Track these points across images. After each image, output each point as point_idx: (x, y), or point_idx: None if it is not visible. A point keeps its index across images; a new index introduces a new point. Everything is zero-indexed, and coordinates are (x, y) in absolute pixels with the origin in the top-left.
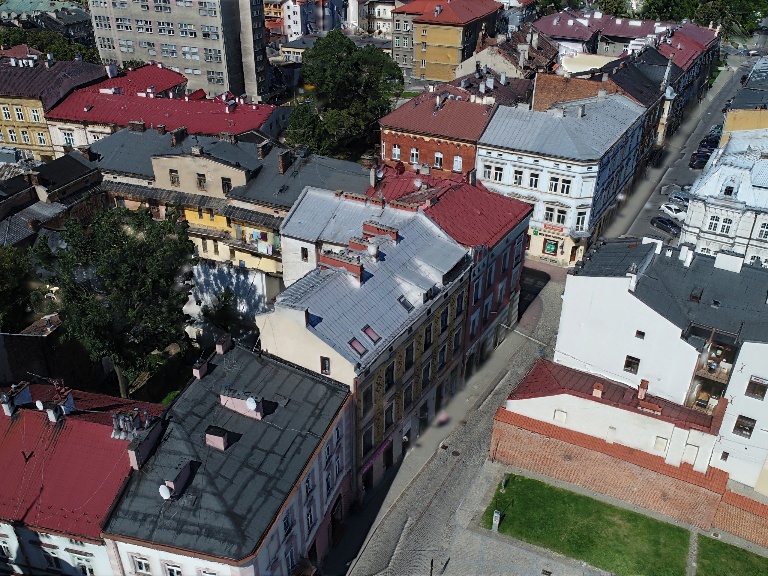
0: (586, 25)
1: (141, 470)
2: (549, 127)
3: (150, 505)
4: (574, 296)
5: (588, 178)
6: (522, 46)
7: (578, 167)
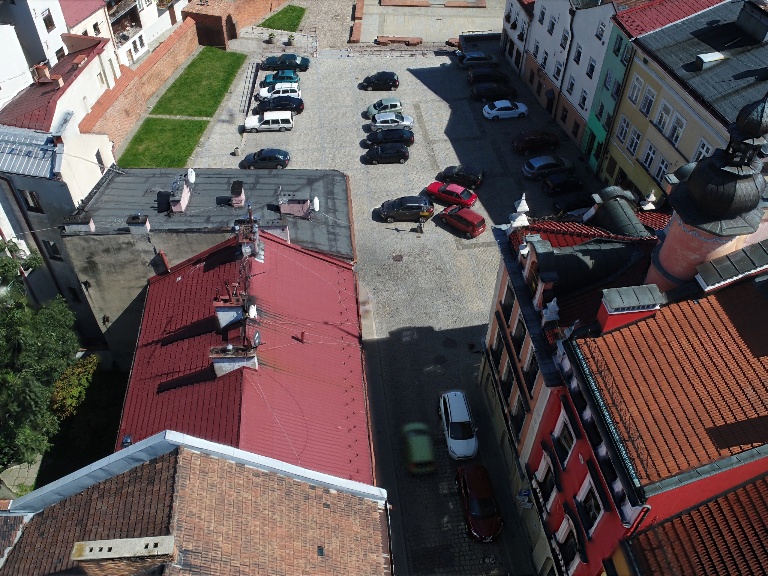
0: None
1: None
2: None
3: (320, 232)
4: None
5: None
6: None
7: None
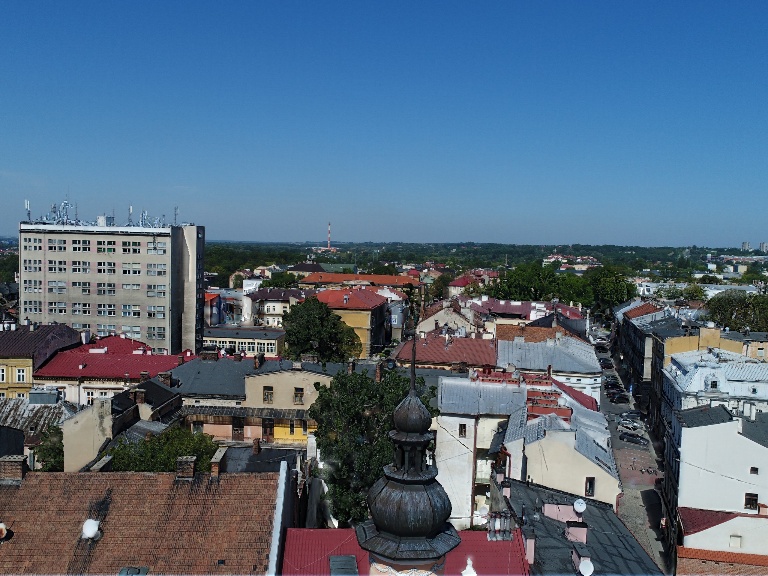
0: (480, 305)
1: (535, 564)
2: (548, 352)
3: None
4: (690, 447)
5: (595, 389)
6: (465, 310)
7: (587, 379)
